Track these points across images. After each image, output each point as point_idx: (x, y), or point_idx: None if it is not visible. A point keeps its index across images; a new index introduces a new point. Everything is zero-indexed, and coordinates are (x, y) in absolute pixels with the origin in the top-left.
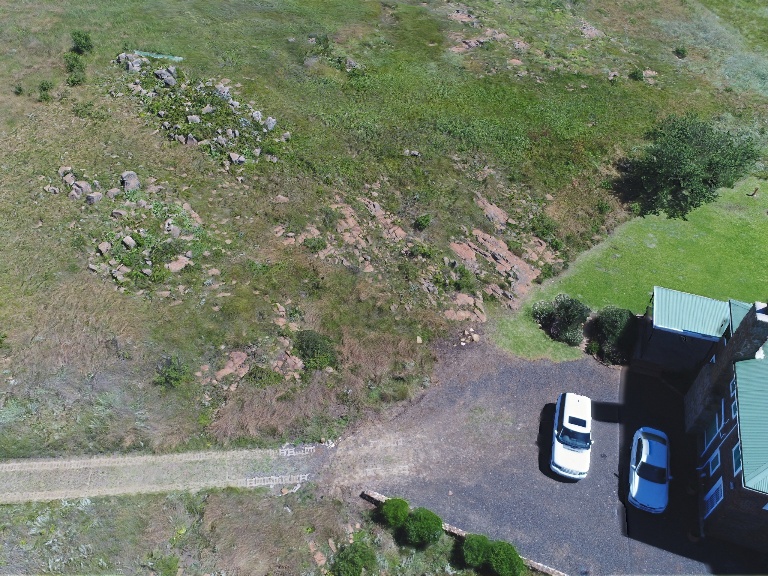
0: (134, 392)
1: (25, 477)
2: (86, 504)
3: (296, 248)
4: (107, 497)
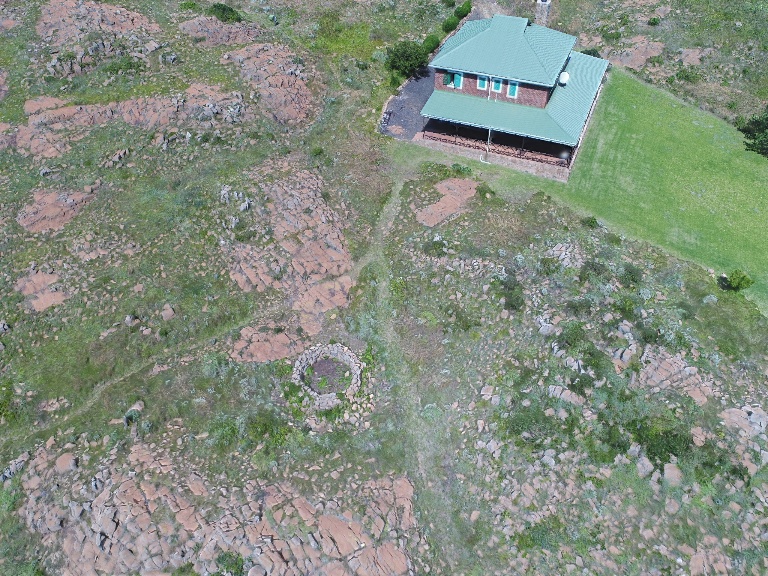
0: None
1: None
2: None
3: None
4: None
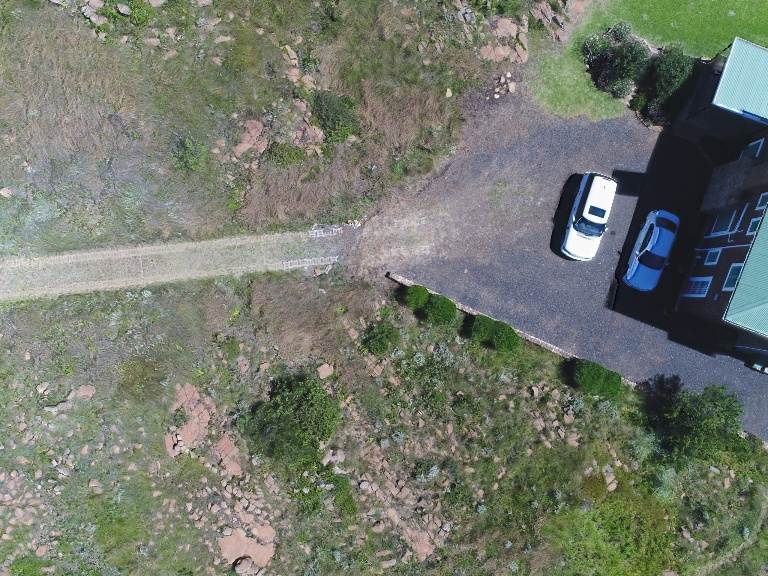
0: (157, 180)
1: (84, 268)
2: (148, 296)
3: None
4: (164, 286)
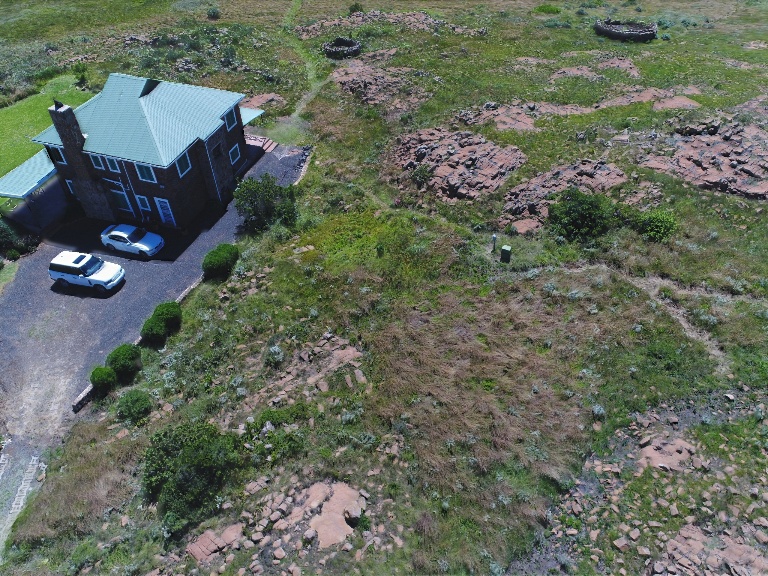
0: None
1: None
2: None
3: None
4: None
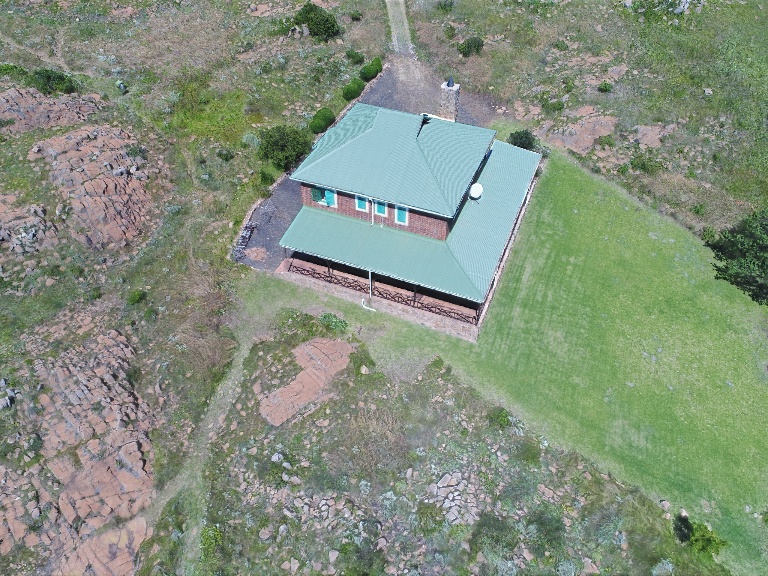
0: None
1: None
2: None
3: (553, 38)
4: None
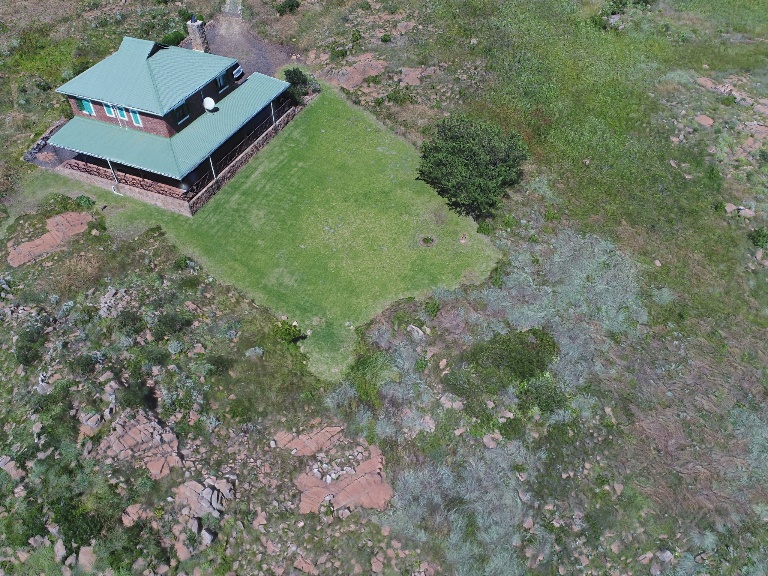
0: None
1: None
2: None
3: None
4: None
